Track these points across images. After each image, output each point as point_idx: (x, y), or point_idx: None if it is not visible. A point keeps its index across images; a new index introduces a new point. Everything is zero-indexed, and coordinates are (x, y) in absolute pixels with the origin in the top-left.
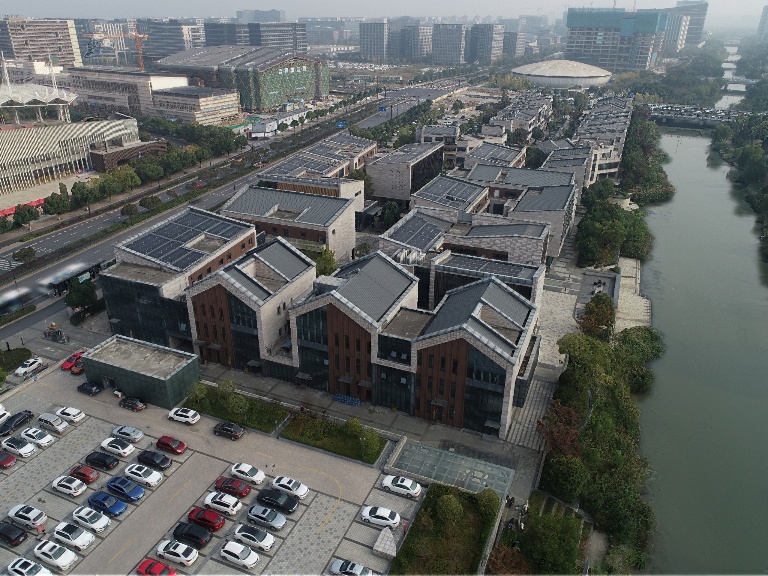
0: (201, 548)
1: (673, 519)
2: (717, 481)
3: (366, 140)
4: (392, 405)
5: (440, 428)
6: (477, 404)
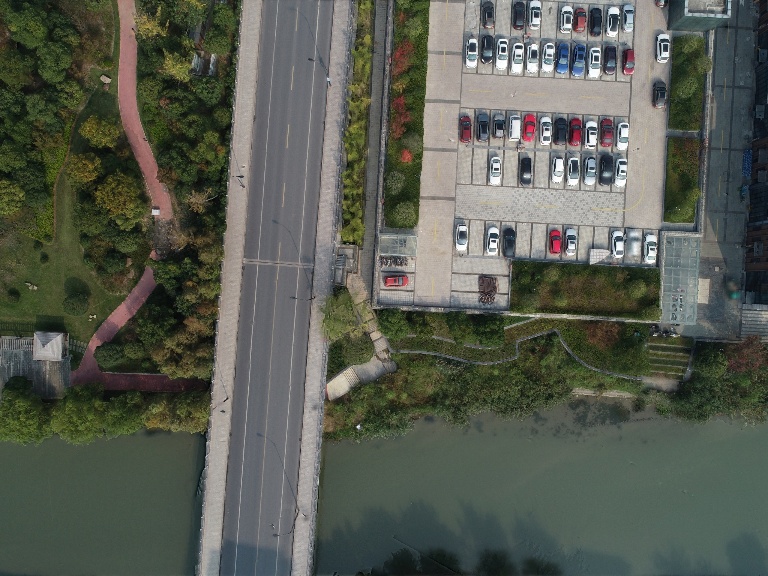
0: (554, 143)
1: (711, 436)
2: (763, 472)
3: None
4: (753, 205)
5: (740, 253)
6: (765, 282)
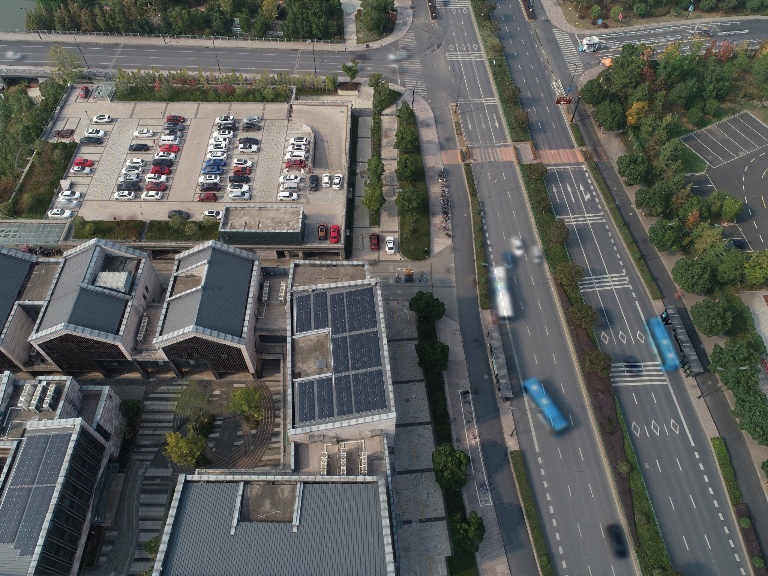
0: None
1: None
2: None
3: None
4: None
5: None
6: None
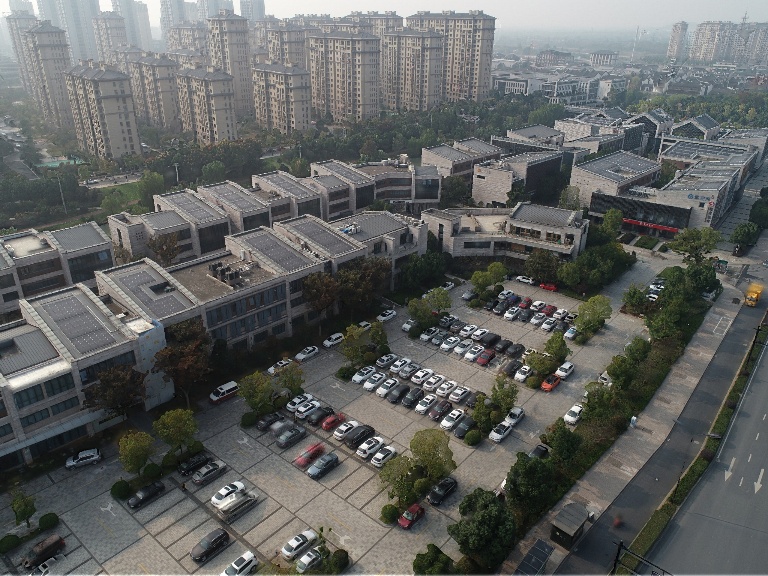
0: None
1: None
2: None
3: (674, 191)
4: None
5: None
6: None
